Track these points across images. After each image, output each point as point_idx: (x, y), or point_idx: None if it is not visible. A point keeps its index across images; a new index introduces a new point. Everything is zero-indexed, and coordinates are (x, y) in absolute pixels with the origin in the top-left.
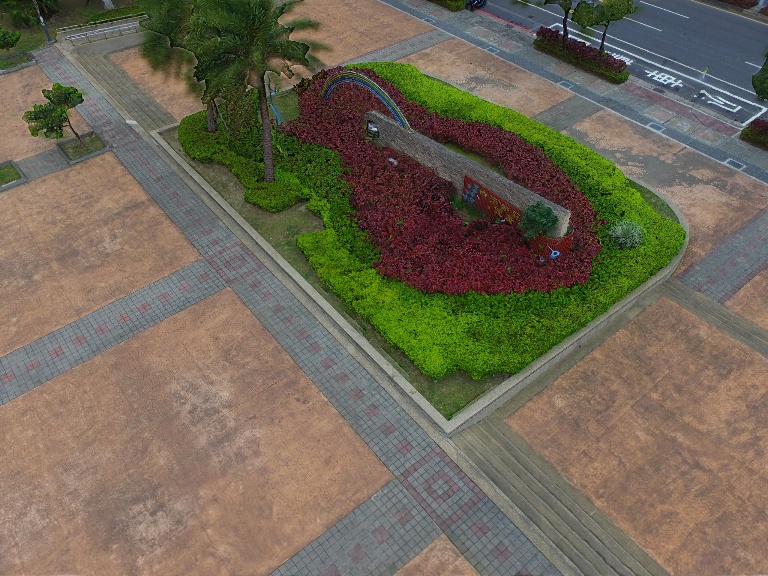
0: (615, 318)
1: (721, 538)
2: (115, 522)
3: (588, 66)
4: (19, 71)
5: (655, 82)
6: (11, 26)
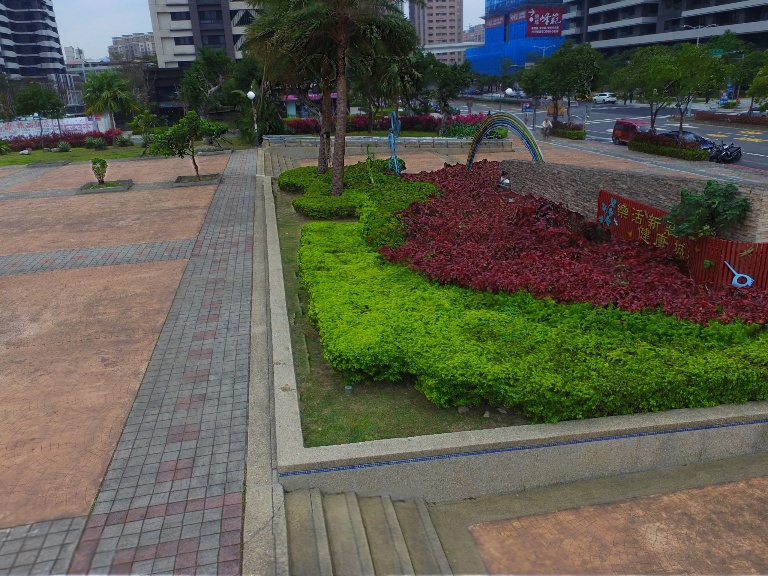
0: None
1: None
2: None
3: None
4: (213, 155)
5: None
6: (239, 141)
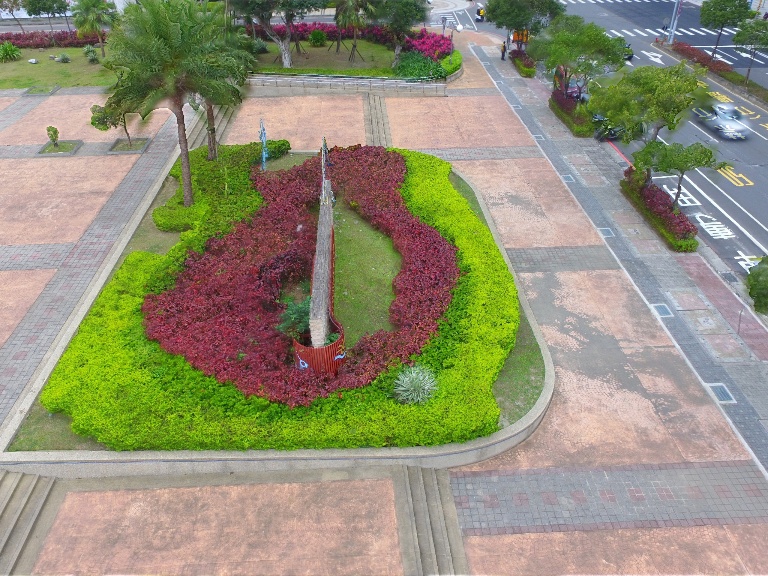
0: (307, 468)
1: None
2: None
3: (653, 221)
4: None
5: (736, 267)
6: None
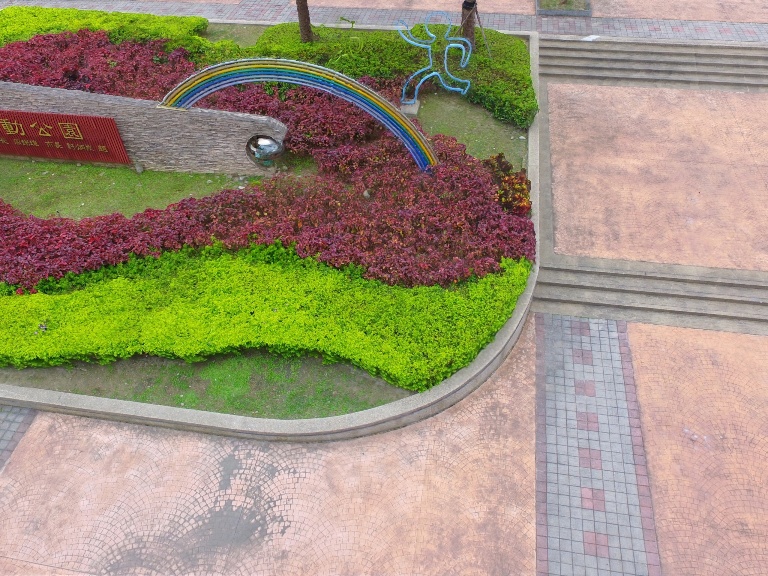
0: None
1: None
2: None
3: None
4: None
5: None
6: None
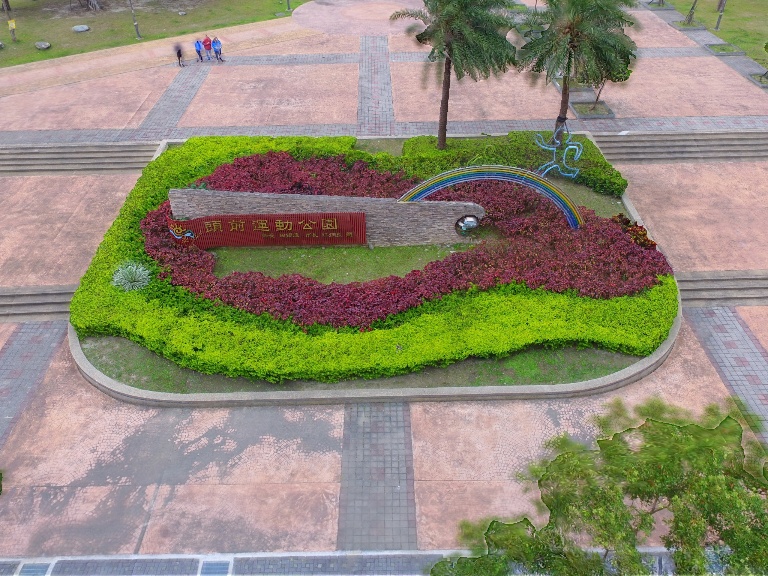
0: None
1: (1, 196)
2: (264, 81)
3: None
4: None
5: None
6: None
